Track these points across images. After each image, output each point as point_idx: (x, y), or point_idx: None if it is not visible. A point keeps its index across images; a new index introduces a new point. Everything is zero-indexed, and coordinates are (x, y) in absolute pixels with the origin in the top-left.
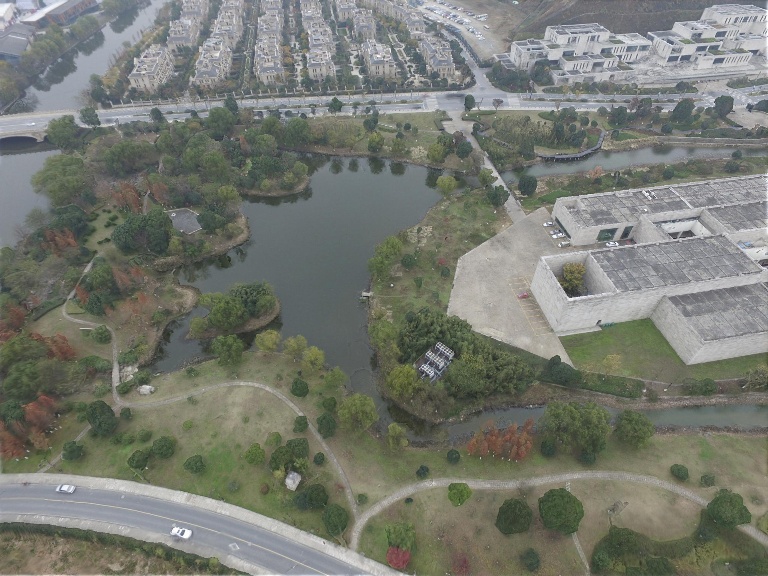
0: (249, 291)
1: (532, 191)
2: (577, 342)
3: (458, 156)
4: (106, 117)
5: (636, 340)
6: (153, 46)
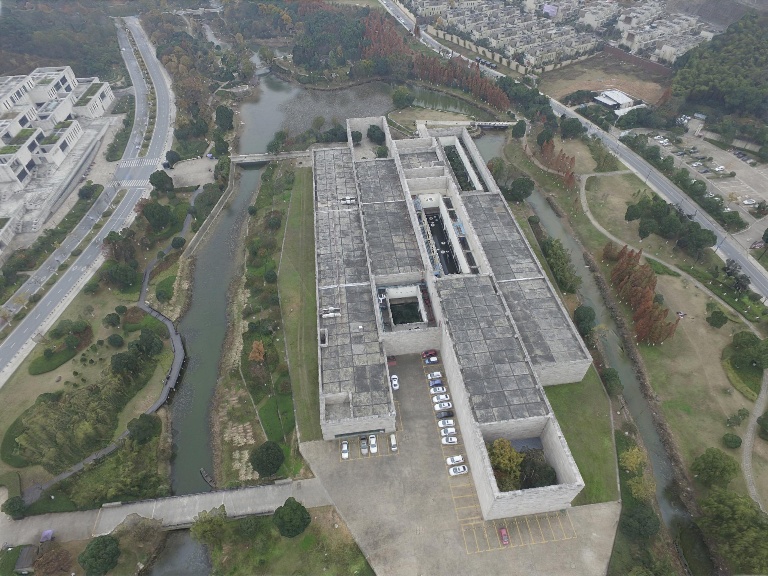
0: None
1: (282, 455)
2: None
3: (103, 575)
4: None
5: (557, 415)
6: None
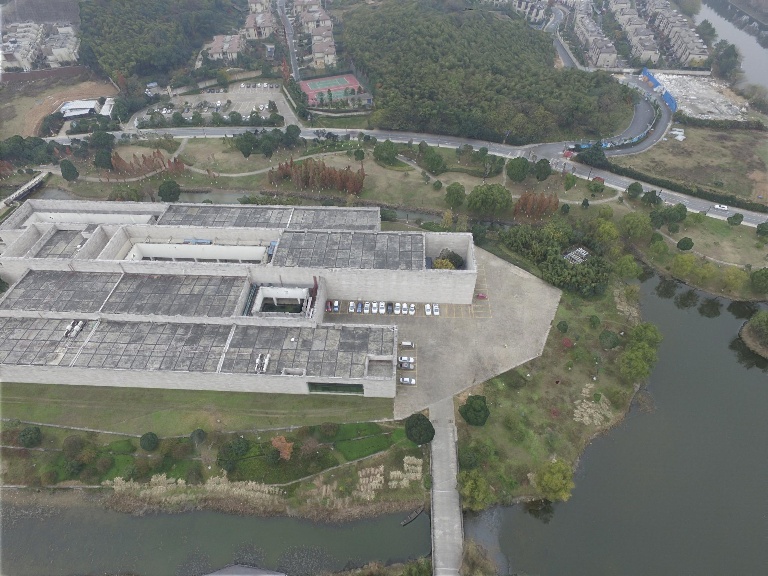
0: None
1: None
2: None
3: None
4: None
5: None
6: None
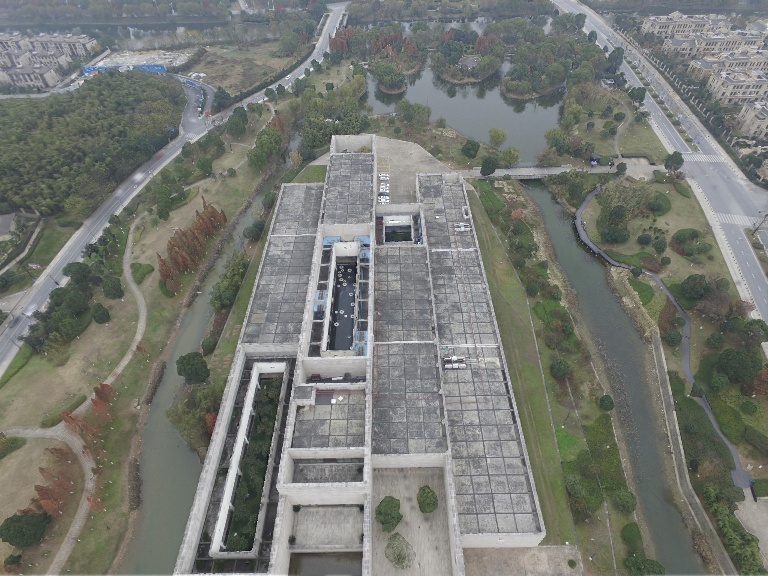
0: (396, 75)
1: None
2: (325, 170)
3: None
4: (601, 32)
5: None
6: (714, 14)
